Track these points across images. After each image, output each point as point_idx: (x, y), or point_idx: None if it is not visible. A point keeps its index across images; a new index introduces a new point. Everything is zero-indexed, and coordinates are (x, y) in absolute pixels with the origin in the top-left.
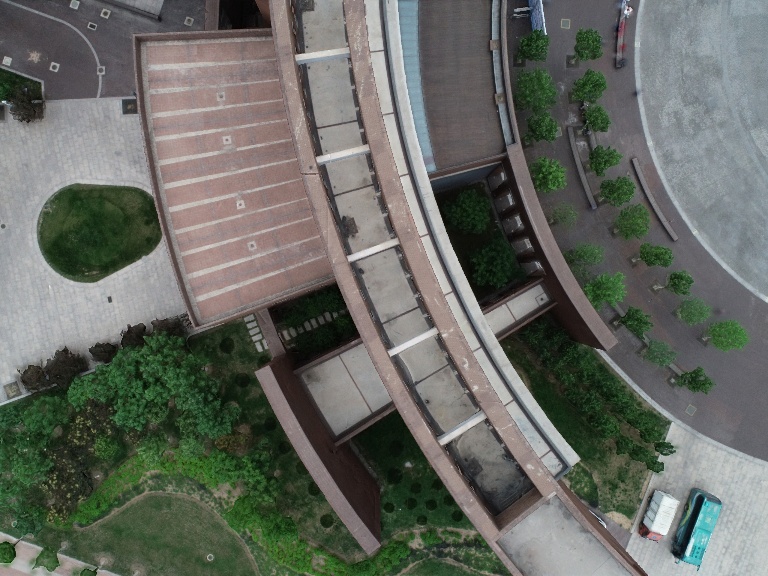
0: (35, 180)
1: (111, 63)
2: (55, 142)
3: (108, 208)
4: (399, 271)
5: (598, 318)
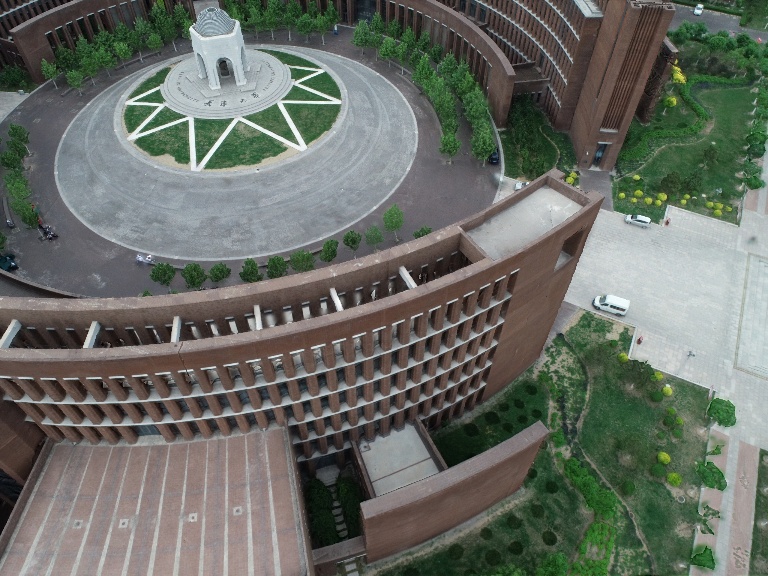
0: None
1: None
2: None
3: None
4: None
5: None
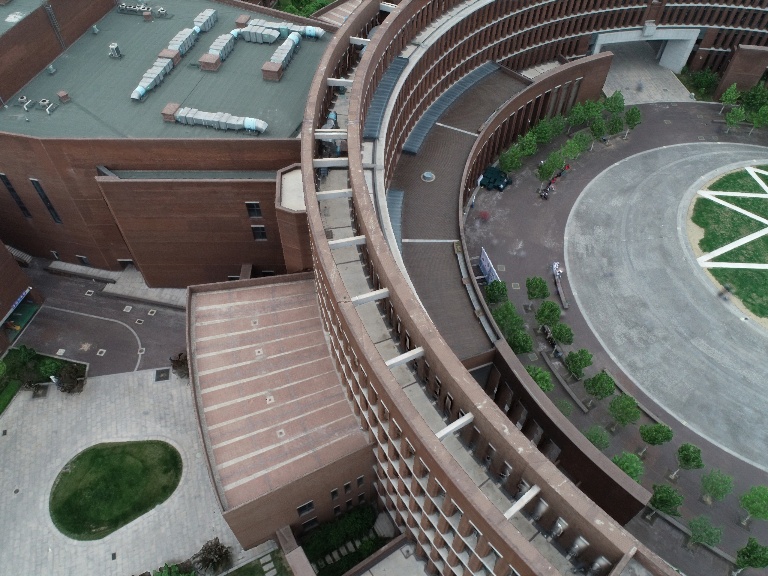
0: (61, 444)
1: (151, 345)
2: (88, 410)
3: (128, 462)
4: (425, 400)
5: (623, 473)
